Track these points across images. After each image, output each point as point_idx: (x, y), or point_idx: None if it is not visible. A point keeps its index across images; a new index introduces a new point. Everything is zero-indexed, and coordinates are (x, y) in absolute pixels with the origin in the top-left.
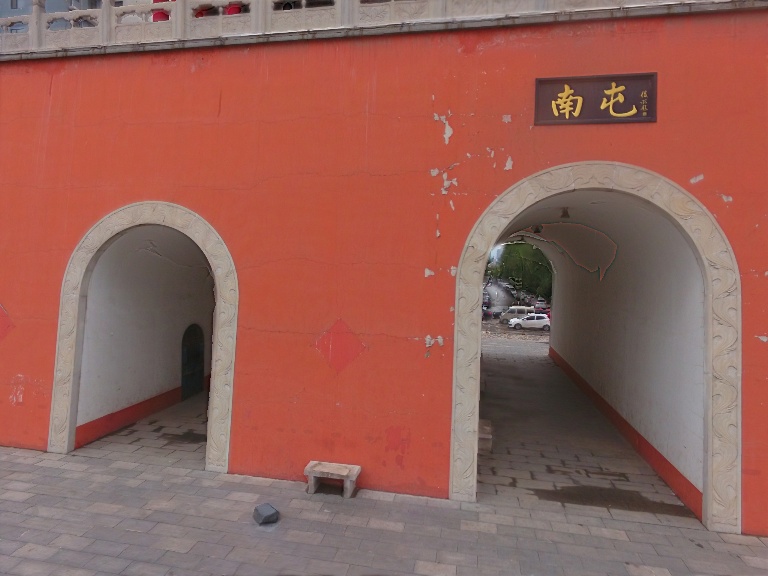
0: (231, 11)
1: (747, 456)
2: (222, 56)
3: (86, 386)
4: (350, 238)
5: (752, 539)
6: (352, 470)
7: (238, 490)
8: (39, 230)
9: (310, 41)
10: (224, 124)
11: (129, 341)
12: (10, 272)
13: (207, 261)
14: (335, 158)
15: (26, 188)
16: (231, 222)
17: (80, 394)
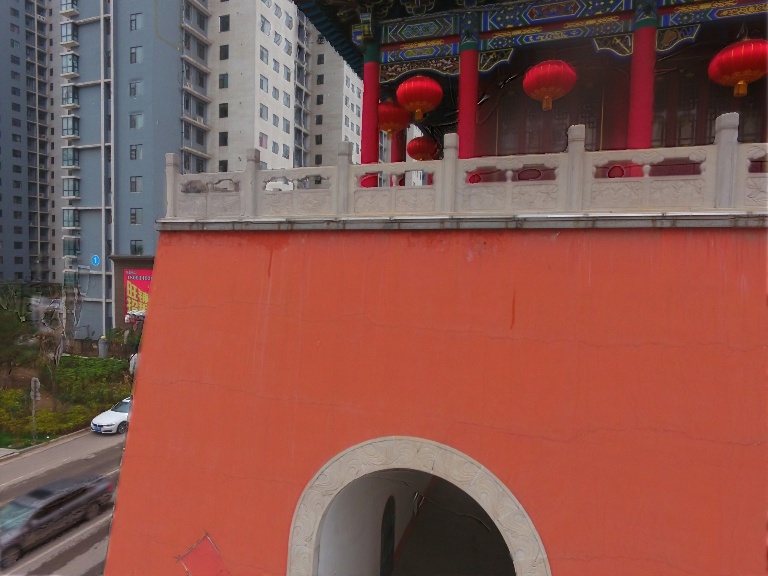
0: (468, 137)
1: None
2: (515, 241)
3: None
4: (749, 545)
5: None
6: None
7: None
8: (257, 450)
9: (665, 230)
10: (521, 340)
11: (346, 566)
12: (221, 499)
13: (501, 538)
14: (714, 412)
15: (240, 394)
16: (536, 484)
17: None
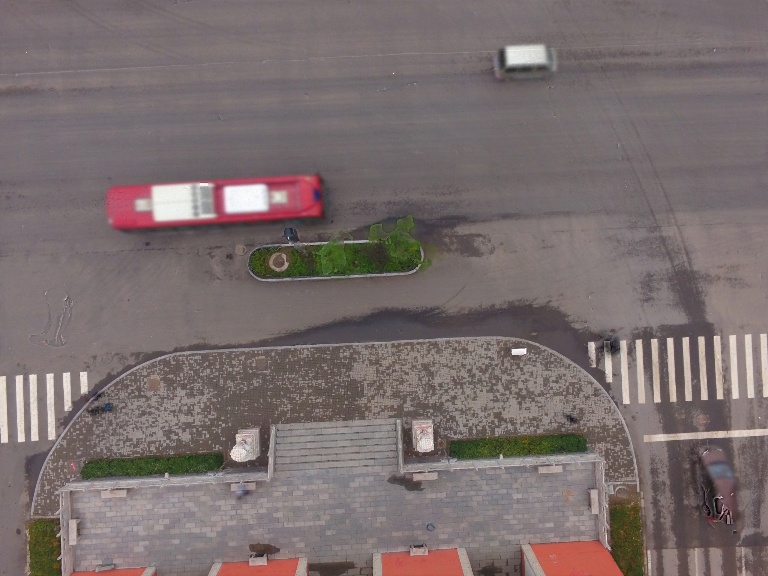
0: None
1: (294, 574)
2: None
3: (529, 568)
4: None
5: (298, 556)
6: (412, 552)
7: (447, 539)
8: None
9: None
10: None
11: None
12: None
13: None
14: None
15: None
16: None
17: (528, 563)
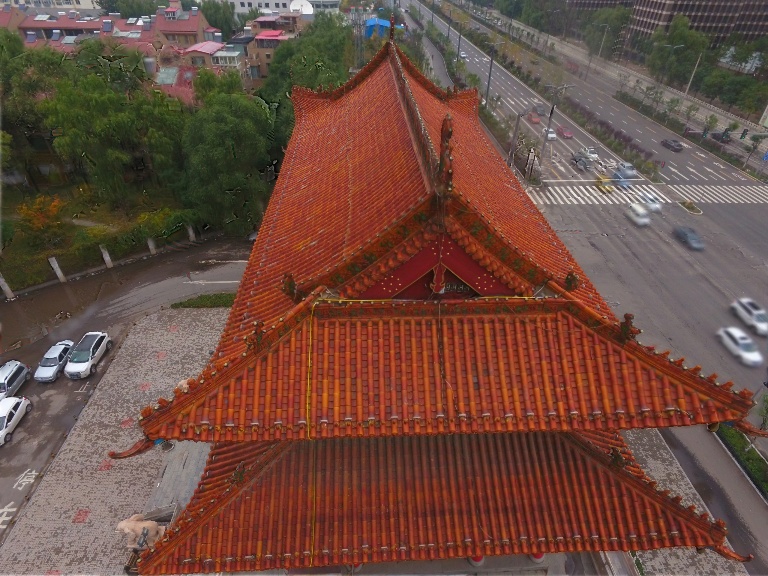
0: None
1: None
2: None
3: None
4: None
5: None
6: None
7: None
8: None
9: None
10: None
11: None
12: None
13: None
14: None
15: None
16: None
17: None
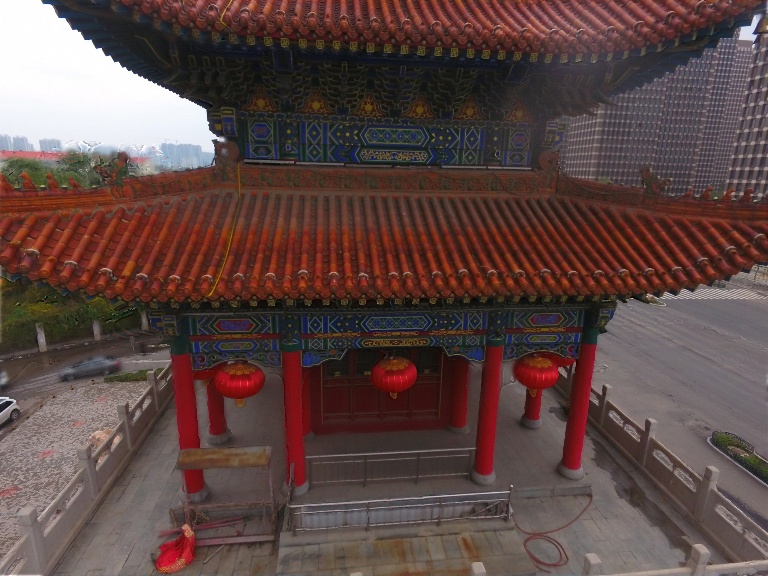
0: None
1: None
2: None
3: None
4: None
5: None
6: None
7: None
8: None
9: None
10: None
11: None
12: None
13: None
14: None
15: None
16: None
17: None
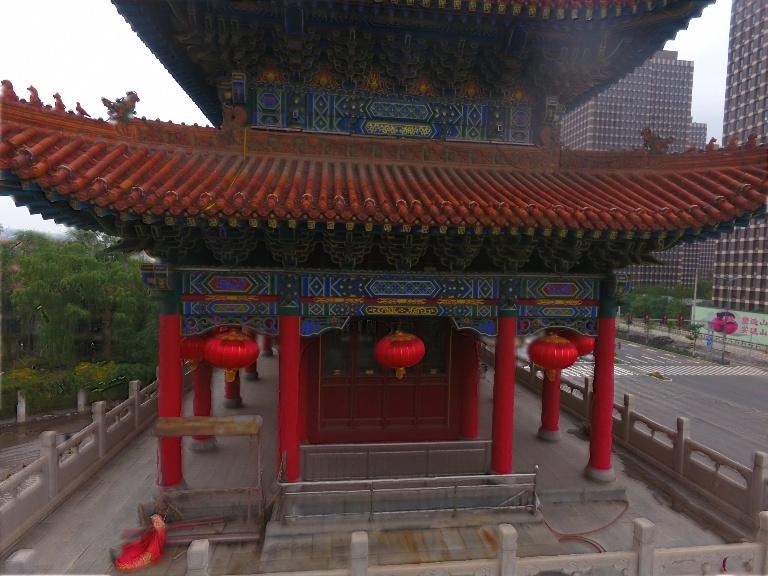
0: None
1: None
2: None
3: None
4: None
5: None
6: None
7: None
8: None
9: None
10: None
11: None
12: None
13: None
14: None
15: None
16: None
17: None
